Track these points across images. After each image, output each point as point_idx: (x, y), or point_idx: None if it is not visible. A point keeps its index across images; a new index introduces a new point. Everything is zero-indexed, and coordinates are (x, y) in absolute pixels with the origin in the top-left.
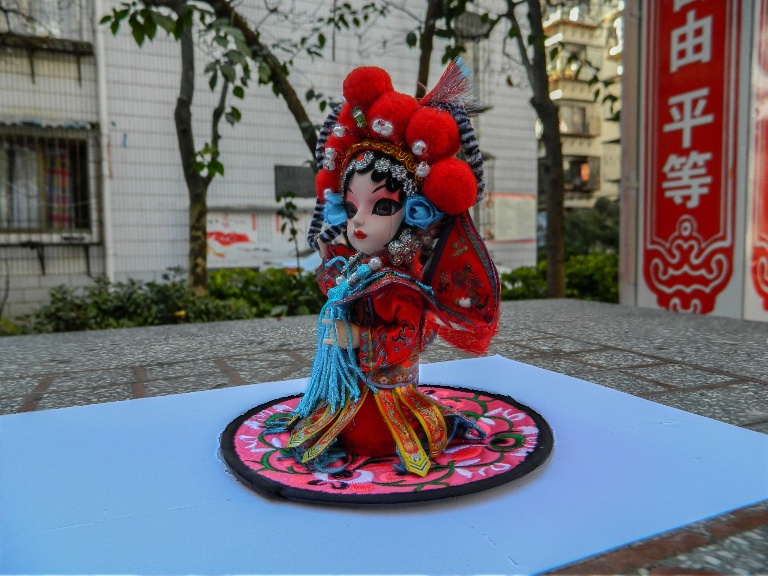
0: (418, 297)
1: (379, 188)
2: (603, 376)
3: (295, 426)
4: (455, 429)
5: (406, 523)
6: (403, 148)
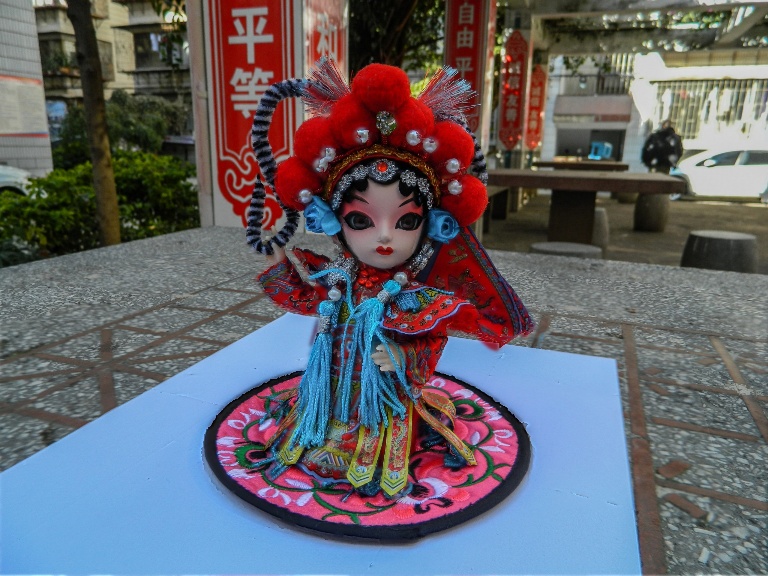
0: (461, 311)
1: (406, 202)
2: None
3: (305, 459)
4: None
5: (524, 510)
6: (426, 161)
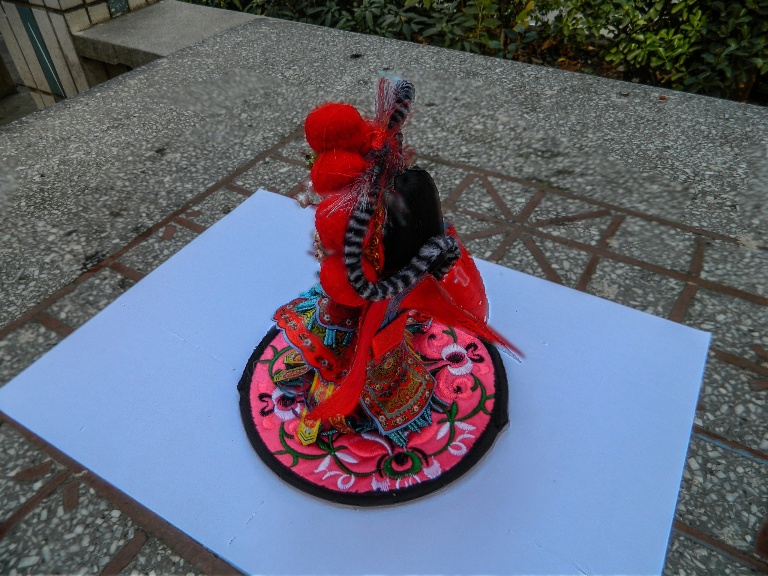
0: None
1: None
2: (732, 465)
3: None
4: (373, 427)
5: (249, 466)
6: None
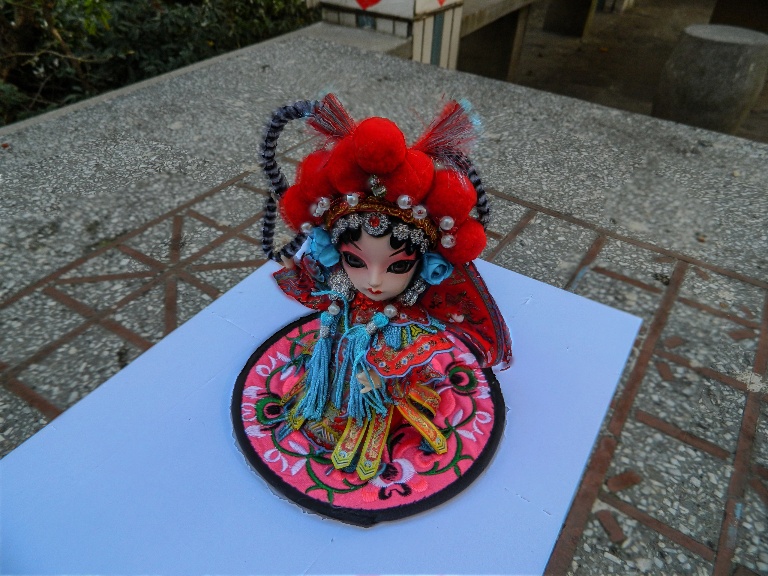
0: None
1: (397, 252)
2: None
3: (306, 427)
4: None
5: (469, 506)
6: None
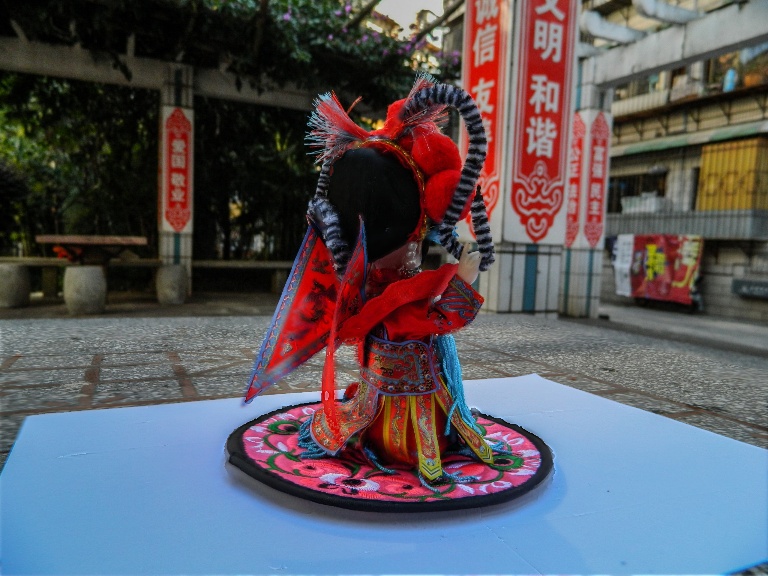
0: None
1: None
2: None
3: None
4: None
5: None
6: None
